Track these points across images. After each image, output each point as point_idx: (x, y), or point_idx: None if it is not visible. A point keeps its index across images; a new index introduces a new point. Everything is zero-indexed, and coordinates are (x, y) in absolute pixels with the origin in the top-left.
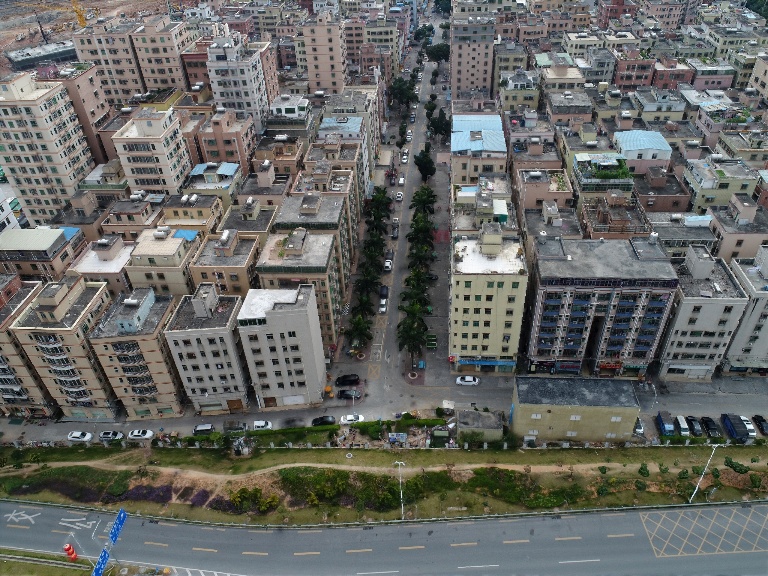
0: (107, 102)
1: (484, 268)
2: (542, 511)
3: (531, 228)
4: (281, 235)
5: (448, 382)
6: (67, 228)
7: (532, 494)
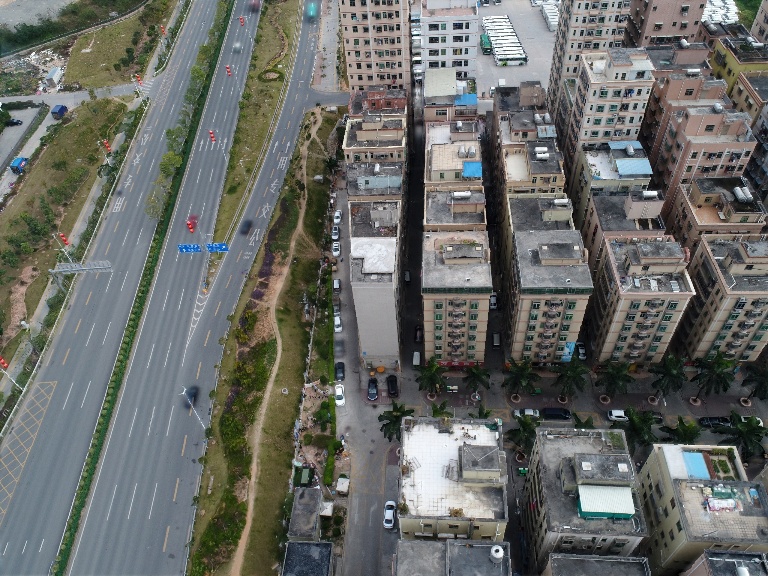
0: (698, 25)
1: (423, 460)
2: (188, 570)
3: (583, 566)
4: (485, 241)
5: (391, 492)
6: (475, 98)
7: (207, 560)
